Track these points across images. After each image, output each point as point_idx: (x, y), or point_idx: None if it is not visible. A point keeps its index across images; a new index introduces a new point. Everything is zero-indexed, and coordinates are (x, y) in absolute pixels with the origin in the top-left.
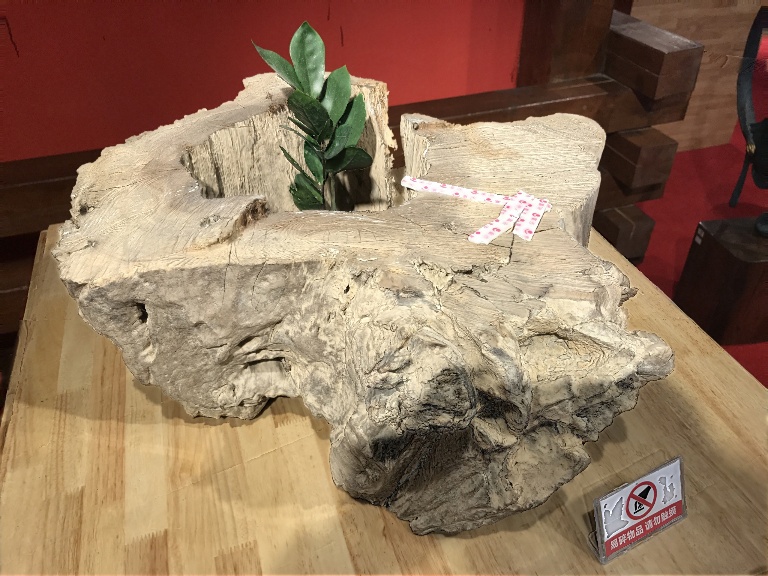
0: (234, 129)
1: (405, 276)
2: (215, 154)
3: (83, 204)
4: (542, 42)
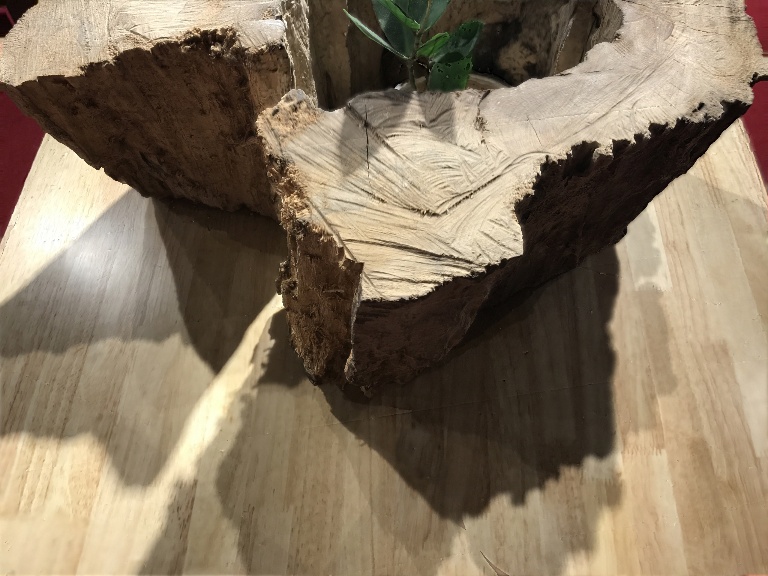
0: None
1: None
2: None
3: None
4: None
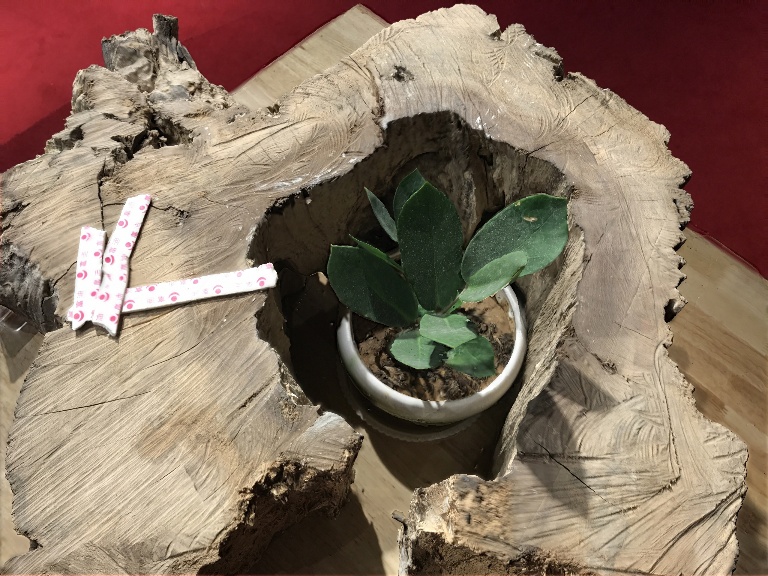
0: None
1: (189, 110)
2: None
3: None
4: (3, 197)
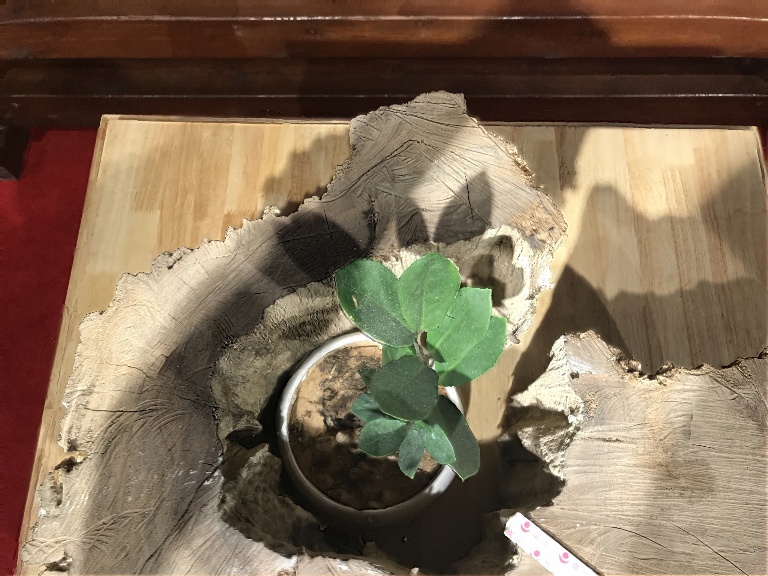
0: (305, 288)
1: None
2: (272, 320)
3: (73, 438)
4: None
